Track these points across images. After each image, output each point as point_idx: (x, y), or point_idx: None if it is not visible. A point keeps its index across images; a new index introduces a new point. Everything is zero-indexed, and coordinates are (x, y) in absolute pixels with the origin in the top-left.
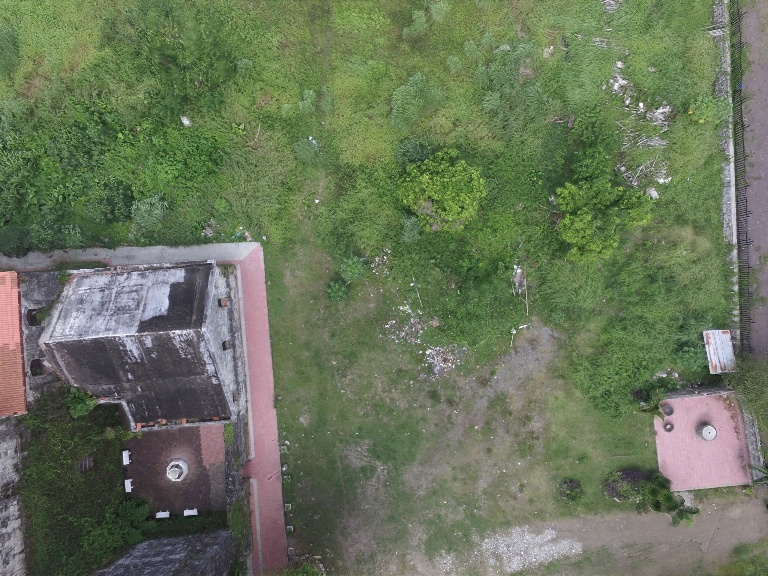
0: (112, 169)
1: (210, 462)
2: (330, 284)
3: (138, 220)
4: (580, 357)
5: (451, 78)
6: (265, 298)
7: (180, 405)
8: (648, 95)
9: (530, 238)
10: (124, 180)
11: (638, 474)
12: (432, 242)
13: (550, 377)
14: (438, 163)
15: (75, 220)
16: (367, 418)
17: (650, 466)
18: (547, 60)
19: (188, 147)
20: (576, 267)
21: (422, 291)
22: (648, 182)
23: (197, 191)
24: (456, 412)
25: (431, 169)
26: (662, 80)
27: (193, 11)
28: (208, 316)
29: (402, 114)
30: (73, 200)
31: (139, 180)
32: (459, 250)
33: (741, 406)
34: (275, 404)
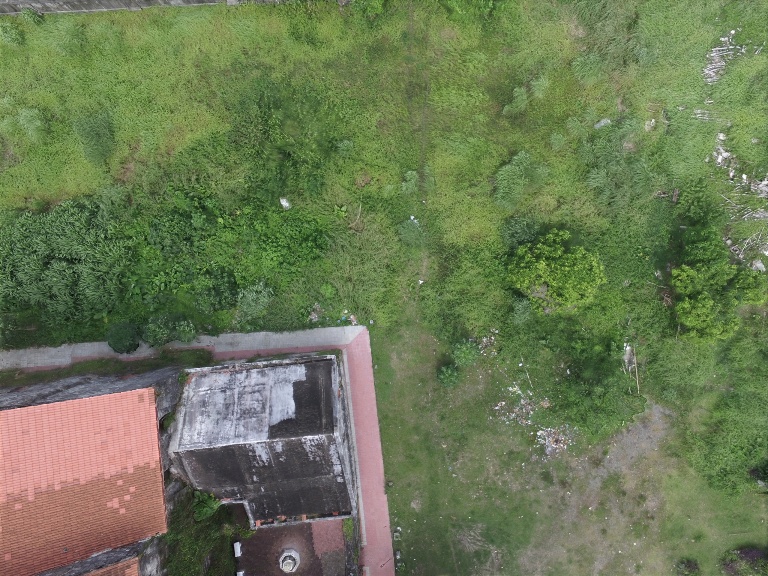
0: (213, 255)
1: (322, 551)
2: (442, 369)
3: (245, 309)
4: (694, 435)
5: (553, 154)
6: (372, 382)
7: (301, 502)
8: (753, 167)
9: (640, 315)
10: (226, 266)
11: (757, 553)
12: (540, 321)
13: (663, 455)
14: (553, 247)
15: (177, 308)
16: (479, 502)
17: (767, 543)
18: (650, 134)
19: (291, 232)
20: (688, 344)
21: (531, 371)
22: (754, 254)
23: (302, 276)
24: (569, 493)
25: (546, 254)
26: (767, 152)
27: (289, 91)
28: (338, 419)
29: (509, 194)
30: (175, 287)
31: (241, 265)
32: (568, 329)
33: None
34: (386, 490)
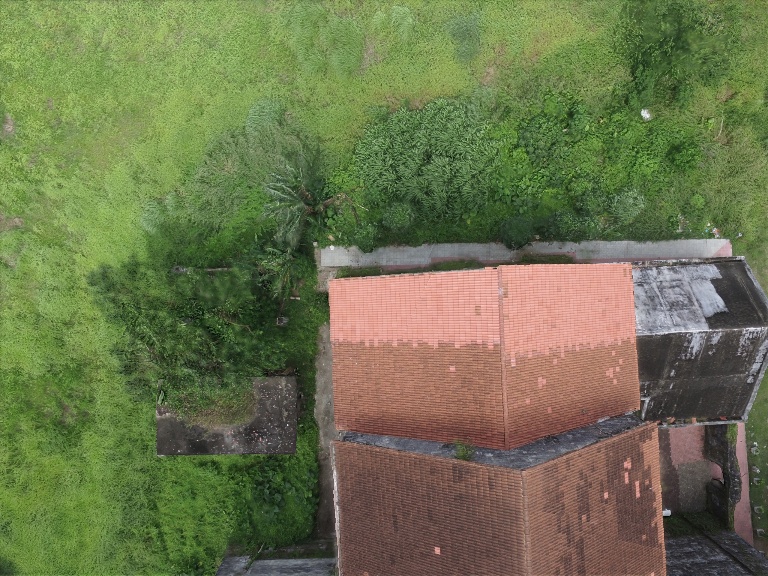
0: (579, 161)
1: (679, 462)
2: None
3: (620, 214)
4: None
5: None
6: None
7: (698, 404)
8: None
9: None
10: (590, 173)
11: None
12: None
13: None
14: None
15: (541, 212)
16: None
17: None
18: None
19: (662, 141)
20: None
21: None
22: None
23: (671, 186)
24: None
25: None
26: None
27: (653, 2)
28: None
29: None
30: (540, 192)
31: (605, 173)
32: None
33: None
34: None
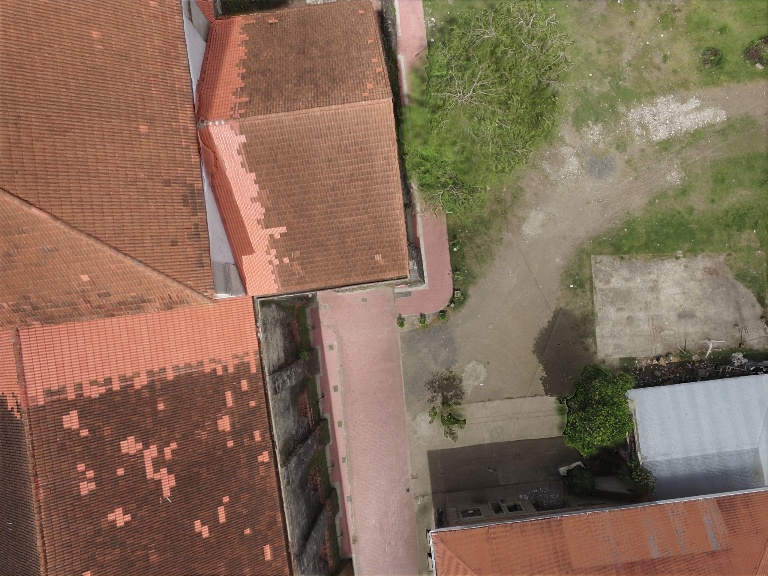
0: None
1: None
2: None
3: None
4: None
5: None
6: None
7: None
8: None
9: None
10: None
11: None
12: None
13: None
14: None
15: None
16: None
17: None
18: None
19: None
20: None
21: None
22: None
23: None
24: None
25: None
26: None
27: None
28: None
29: None
30: None
31: None
32: None
33: None
34: None
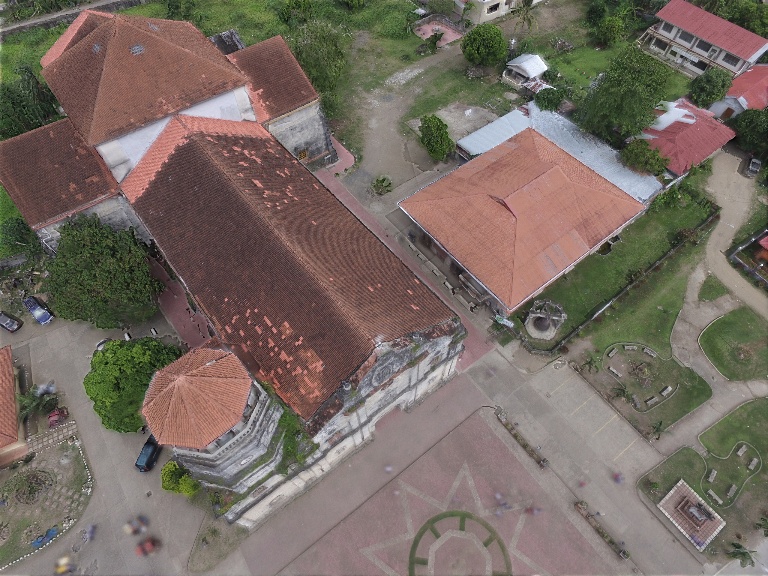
0: None
1: None
2: None
3: None
4: None
5: (282, 0)
6: None
7: None
8: None
9: None
10: None
11: (422, 44)
12: None
13: (372, 40)
14: None
15: None
16: None
17: None
18: None
19: None
20: None
21: None
22: None
23: None
24: None
25: None
26: None
27: None
28: None
29: None
30: None
31: None
32: None
33: (441, 22)
34: None
